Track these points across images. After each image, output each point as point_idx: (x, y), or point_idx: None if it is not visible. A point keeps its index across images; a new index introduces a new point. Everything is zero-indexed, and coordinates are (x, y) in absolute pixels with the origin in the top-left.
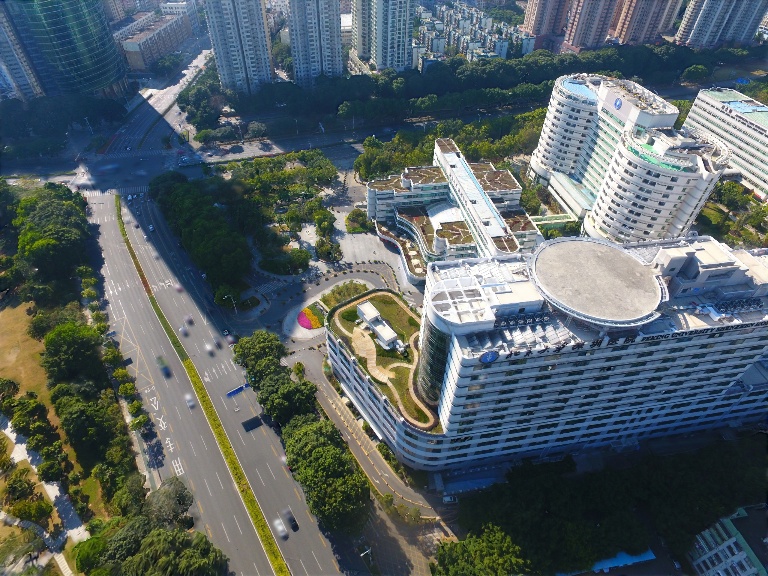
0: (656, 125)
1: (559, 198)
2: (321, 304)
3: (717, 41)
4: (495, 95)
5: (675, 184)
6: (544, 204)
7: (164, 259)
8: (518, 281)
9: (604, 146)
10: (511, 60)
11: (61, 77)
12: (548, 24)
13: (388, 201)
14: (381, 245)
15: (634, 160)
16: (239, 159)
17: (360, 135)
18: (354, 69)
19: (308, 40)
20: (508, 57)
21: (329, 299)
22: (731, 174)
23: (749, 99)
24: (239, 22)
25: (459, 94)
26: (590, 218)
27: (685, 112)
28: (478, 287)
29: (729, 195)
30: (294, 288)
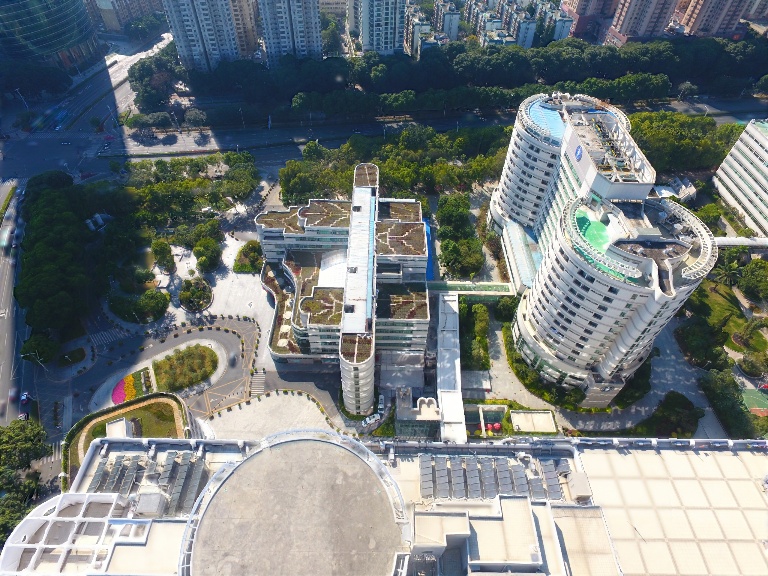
0: (618, 196)
1: (506, 258)
2: (150, 372)
3: None
4: (491, 96)
5: (615, 296)
6: (494, 258)
7: (16, 280)
8: (172, 520)
9: (560, 205)
10: (528, 49)
11: (3, 39)
12: (596, 2)
13: (276, 241)
14: (263, 294)
15: (565, 249)
16: (164, 153)
17: (316, 134)
18: (347, 45)
19: (276, 11)
20: (535, 42)
21: (163, 366)
22: (766, 246)
23: None
24: None
25: (444, 92)
26: (524, 301)
27: (734, 142)
28: (104, 521)
29: (750, 280)
30: (133, 343)
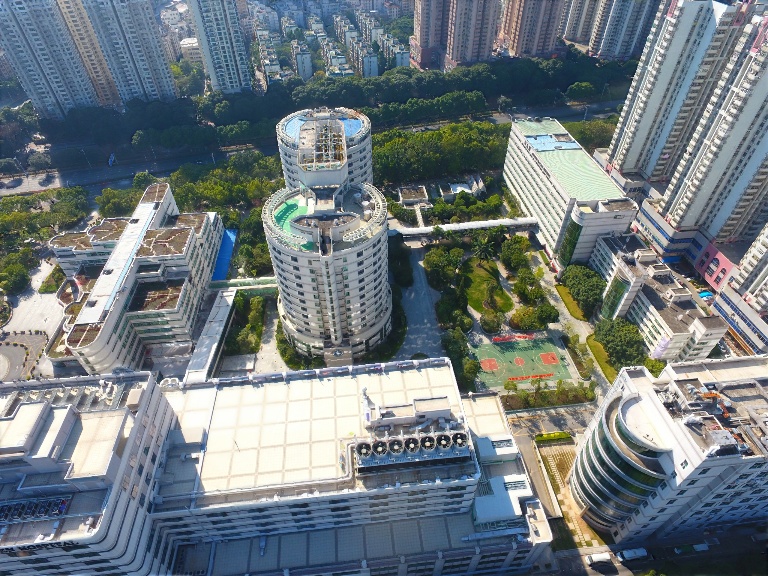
0: (317, 183)
1: None
2: None
3: (633, 51)
4: None
5: (298, 264)
6: None
7: None
8: None
9: None
10: (362, 79)
11: None
12: (434, 35)
13: (69, 259)
14: (61, 309)
15: None
16: (5, 195)
17: (159, 167)
18: None
19: (121, 61)
20: (380, 73)
21: None
22: (528, 224)
23: (564, 132)
24: (31, 44)
25: (277, 120)
26: None
27: None
28: None
29: (505, 253)
30: None
